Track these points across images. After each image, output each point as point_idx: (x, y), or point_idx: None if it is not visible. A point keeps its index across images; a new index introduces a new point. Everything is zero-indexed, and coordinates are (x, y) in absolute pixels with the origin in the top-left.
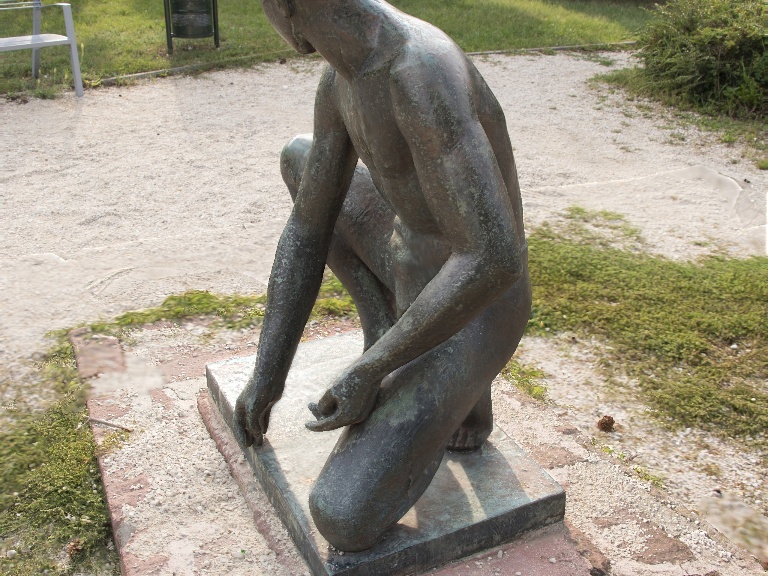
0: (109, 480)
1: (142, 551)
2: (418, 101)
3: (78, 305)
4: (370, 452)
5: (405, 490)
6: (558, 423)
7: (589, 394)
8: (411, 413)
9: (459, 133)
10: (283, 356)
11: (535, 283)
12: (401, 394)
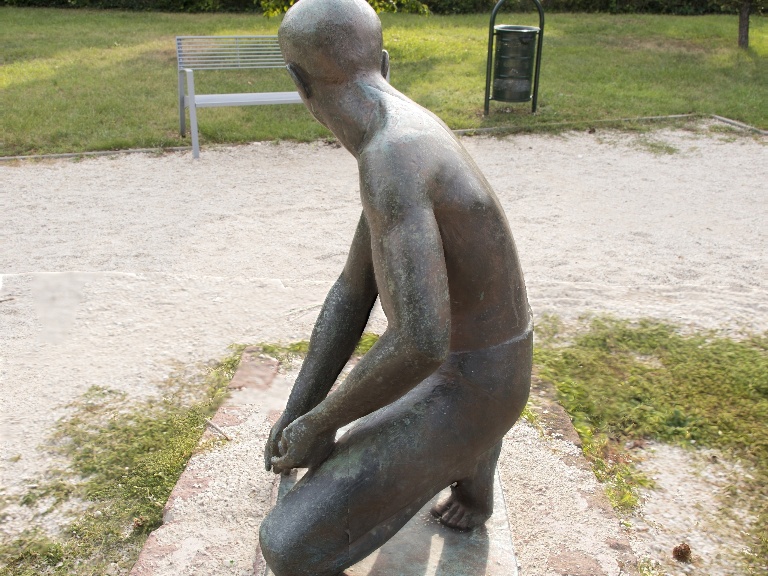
0: (184, 475)
1: (164, 538)
2: (369, 183)
3: (271, 327)
4: (311, 497)
5: (343, 543)
6: (614, 535)
7: (690, 518)
8: (354, 471)
9: (399, 217)
10: (310, 398)
11: (711, 391)
12: (350, 451)
